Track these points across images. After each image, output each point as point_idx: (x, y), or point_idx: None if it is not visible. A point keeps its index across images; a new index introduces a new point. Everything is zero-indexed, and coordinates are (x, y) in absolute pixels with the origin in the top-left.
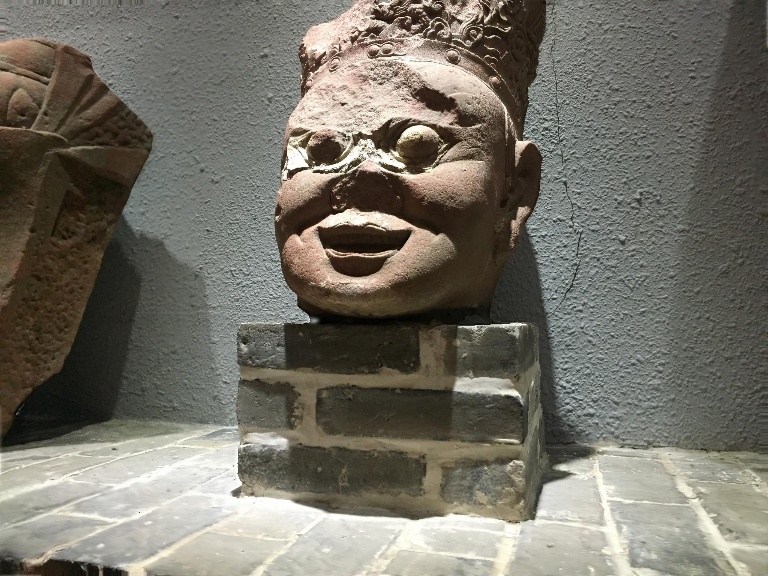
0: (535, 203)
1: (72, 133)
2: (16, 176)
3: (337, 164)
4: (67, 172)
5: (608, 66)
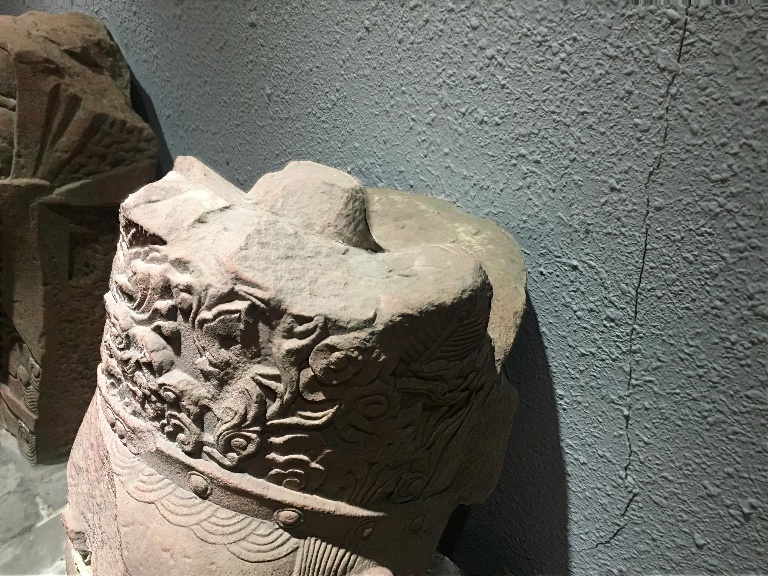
0: None
1: (52, 172)
2: (13, 232)
3: (83, 568)
4: (62, 215)
5: (762, 261)
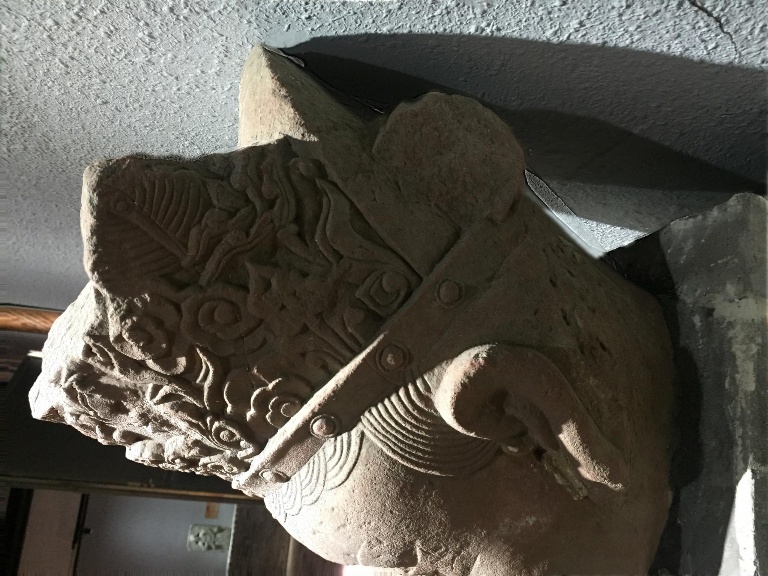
0: (562, 397)
1: None
2: None
3: None
4: None
5: None
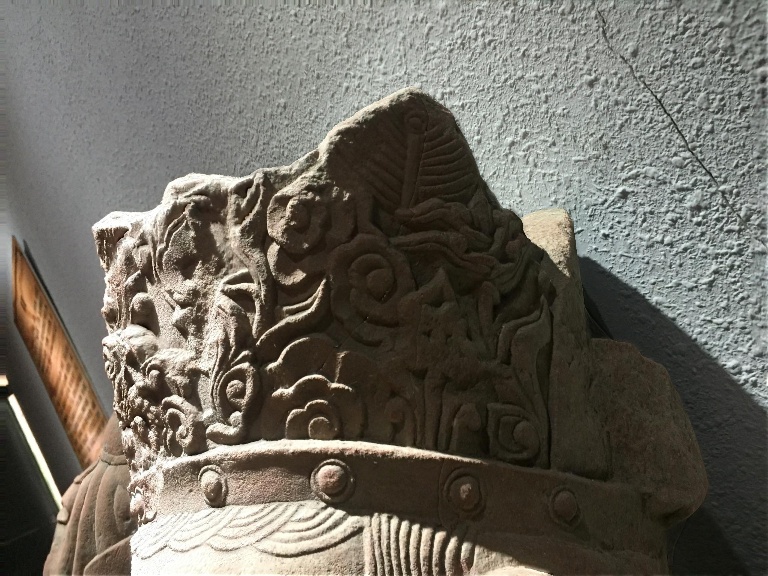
0: None
1: None
2: None
3: None
4: None
5: None
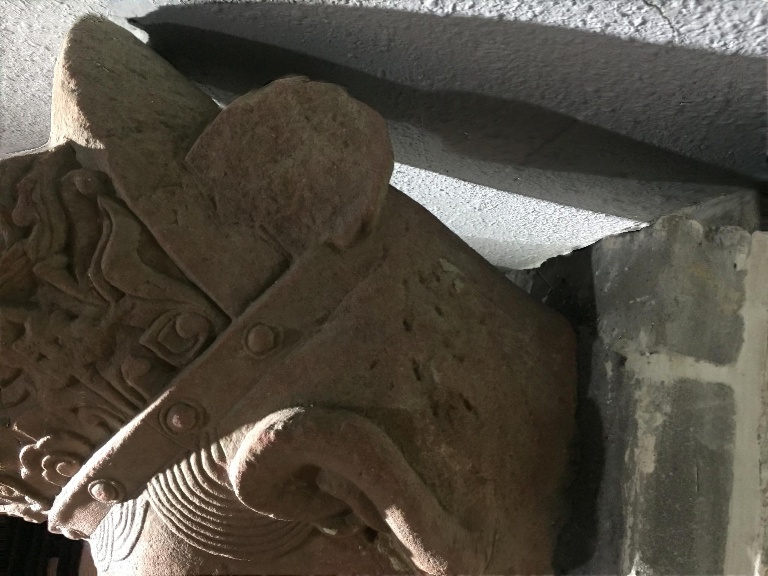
0: (382, 480)
1: None
2: None
3: None
4: None
5: None
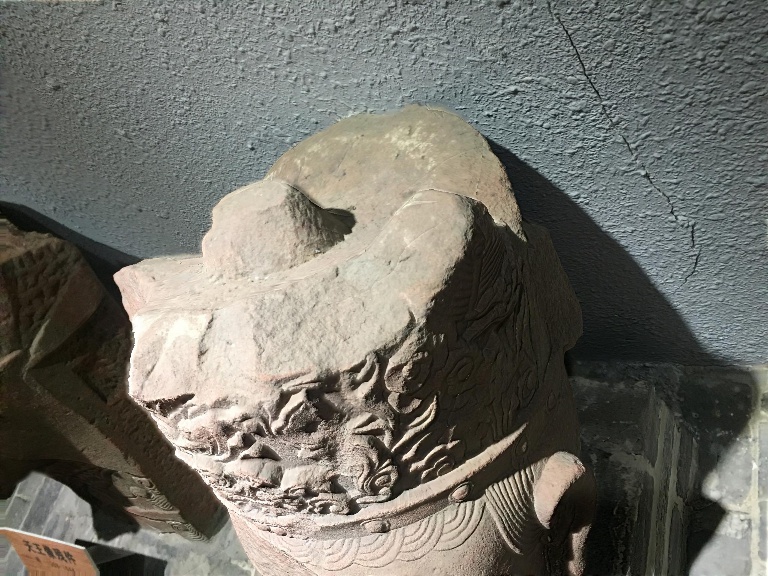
0: None
1: (13, 340)
2: (30, 408)
3: None
4: (54, 363)
5: None
